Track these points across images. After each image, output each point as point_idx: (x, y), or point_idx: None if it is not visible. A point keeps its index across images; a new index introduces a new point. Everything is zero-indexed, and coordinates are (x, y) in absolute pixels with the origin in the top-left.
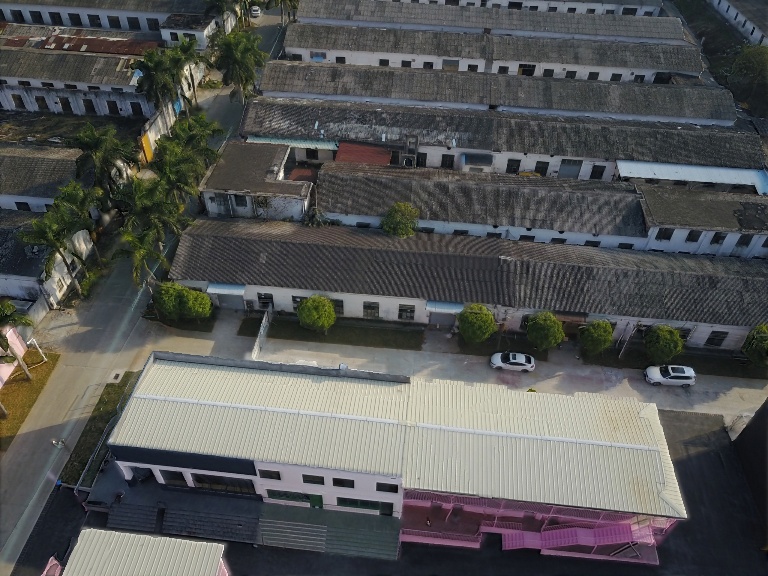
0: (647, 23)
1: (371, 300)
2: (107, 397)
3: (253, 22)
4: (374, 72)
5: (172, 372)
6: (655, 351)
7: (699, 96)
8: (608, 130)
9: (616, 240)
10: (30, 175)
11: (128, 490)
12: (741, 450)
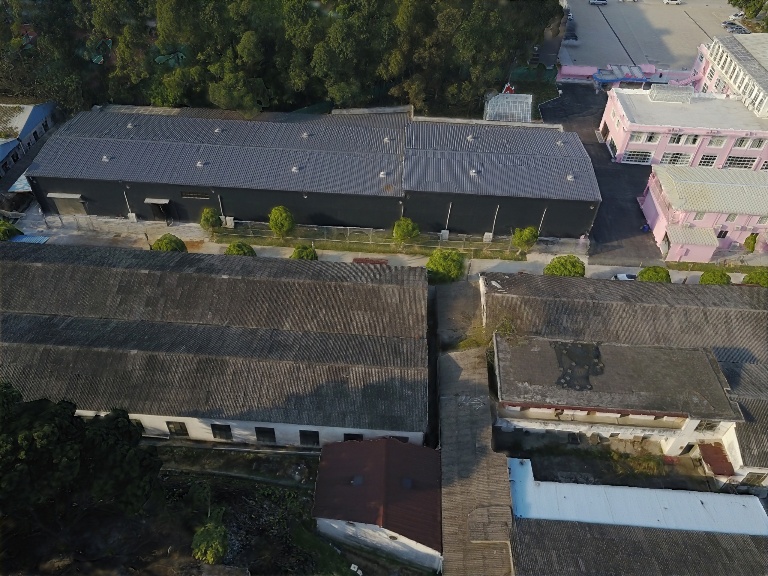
0: None
1: None
2: None
3: None
4: None
5: None
6: None
7: None
8: None
9: None
10: None
11: None
12: None
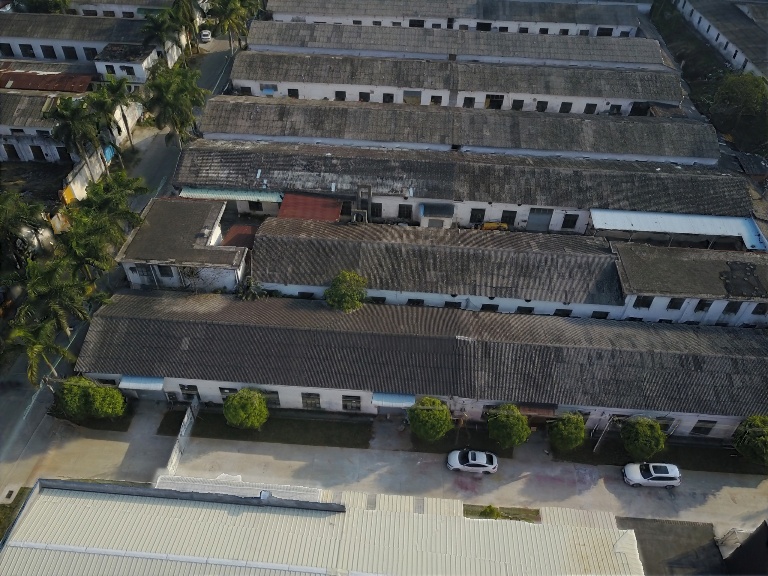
0: (623, 46)
1: (310, 391)
2: None
3: (203, 48)
4: (326, 109)
5: (60, 506)
6: (634, 449)
7: (679, 131)
8: (581, 174)
9: (589, 308)
10: None
11: None
12: (734, 573)
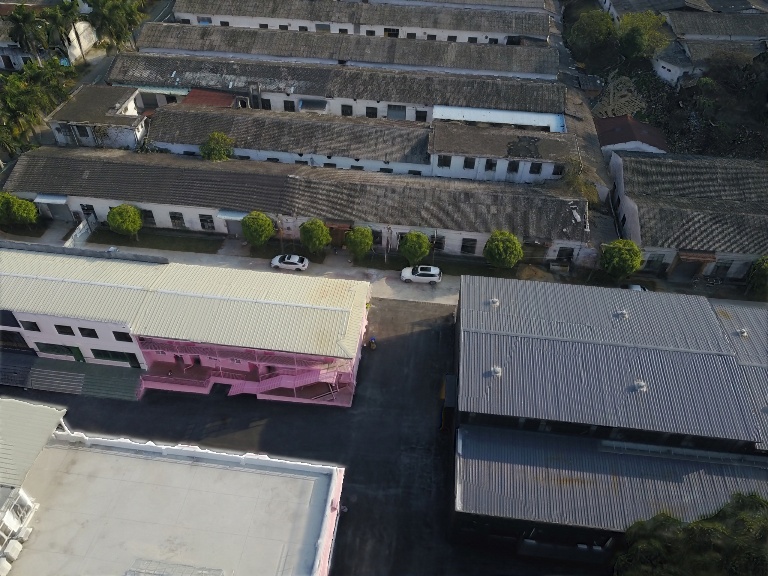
0: None
1: (174, 210)
2: None
3: None
4: (240, 31)
5: None
6: (404, 252)
7: (528, 53)
8: (431, 80)
9: (405, 167)
10: None
11: None
12: None
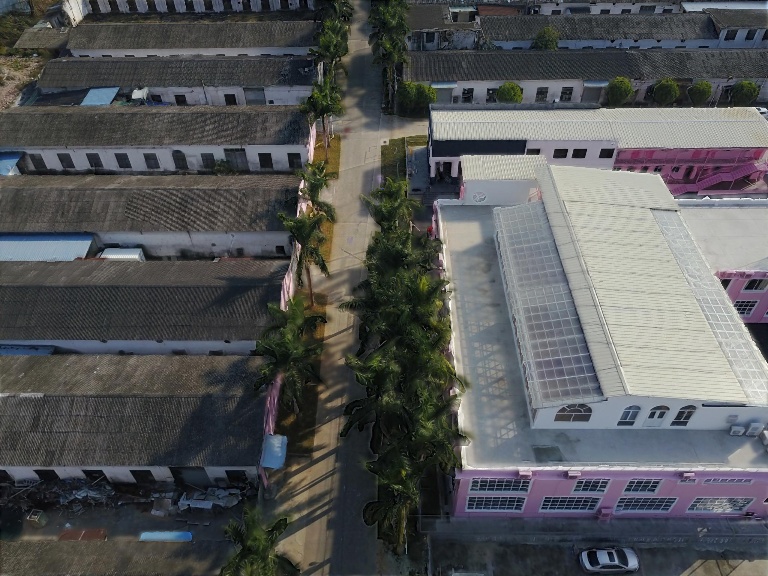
0: None
1: (543, 86)
2: (386, 151)
3: None
4: None
5: (447, 113)
6: (741, 96)
7: None
8: None
9: (697, 44)
10: (270, 34)
11: (431, 186)
12: None
